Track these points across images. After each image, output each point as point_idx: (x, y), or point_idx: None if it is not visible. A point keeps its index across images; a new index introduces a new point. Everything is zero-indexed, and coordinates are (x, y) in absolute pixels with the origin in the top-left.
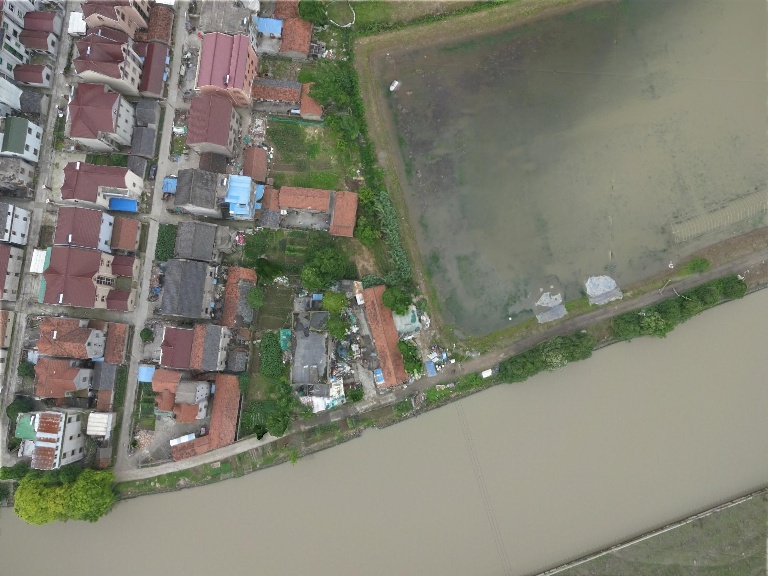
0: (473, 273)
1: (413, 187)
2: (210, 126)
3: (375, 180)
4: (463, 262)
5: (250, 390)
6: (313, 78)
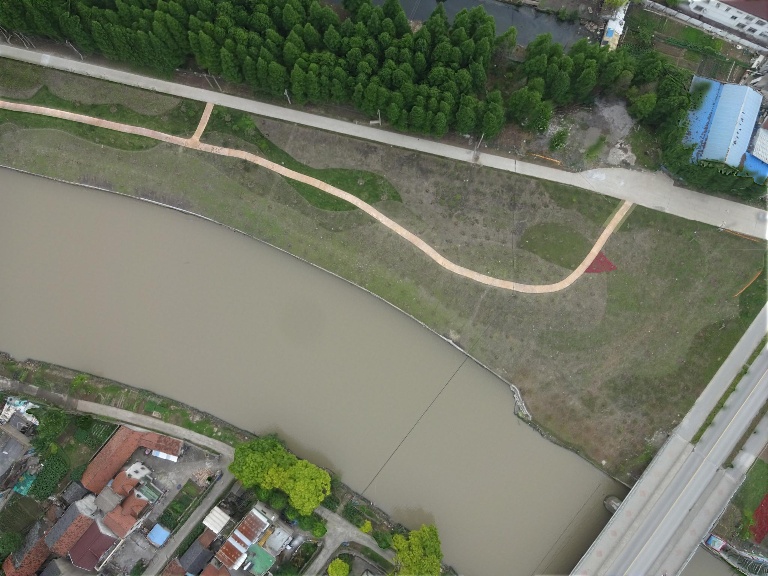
0: None
1: None
2: None
3: None
4: None
5: (88, 459)
6: None
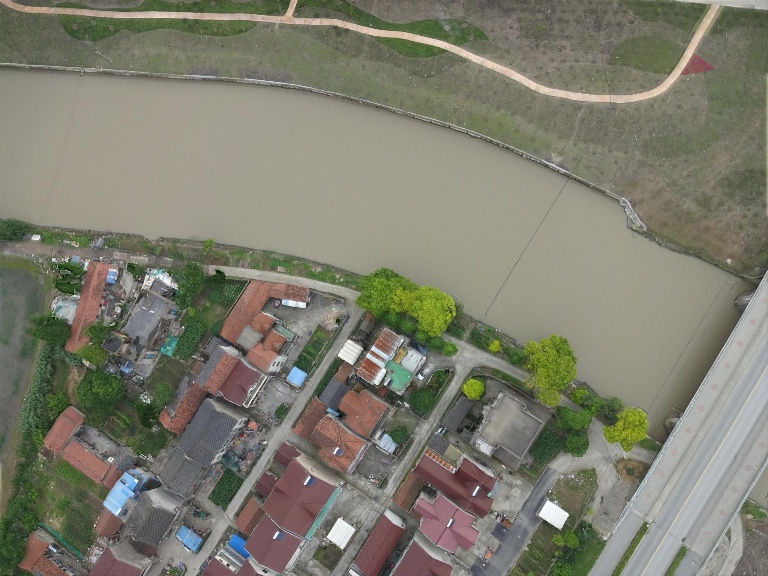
0: (3, 324)
1: (6, 423)
2: (105, 573)
3: (29, 447)
4: (5, 337)
5: None
6: (26, 573)
